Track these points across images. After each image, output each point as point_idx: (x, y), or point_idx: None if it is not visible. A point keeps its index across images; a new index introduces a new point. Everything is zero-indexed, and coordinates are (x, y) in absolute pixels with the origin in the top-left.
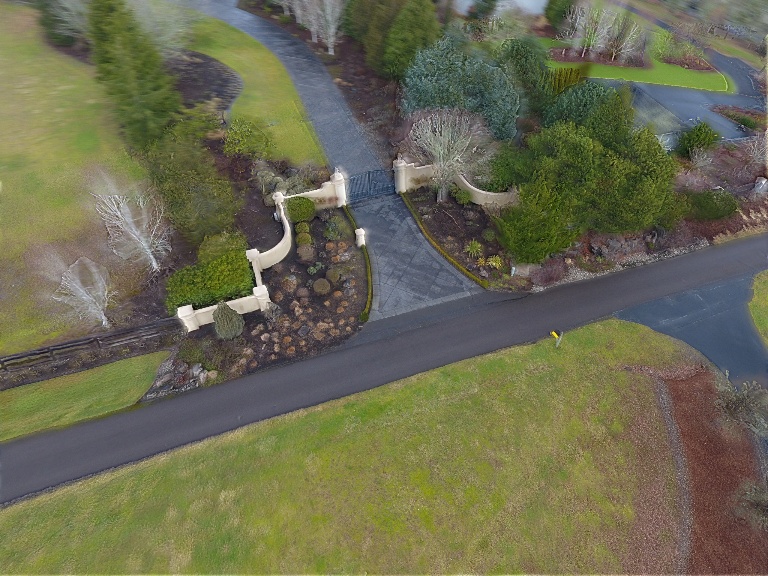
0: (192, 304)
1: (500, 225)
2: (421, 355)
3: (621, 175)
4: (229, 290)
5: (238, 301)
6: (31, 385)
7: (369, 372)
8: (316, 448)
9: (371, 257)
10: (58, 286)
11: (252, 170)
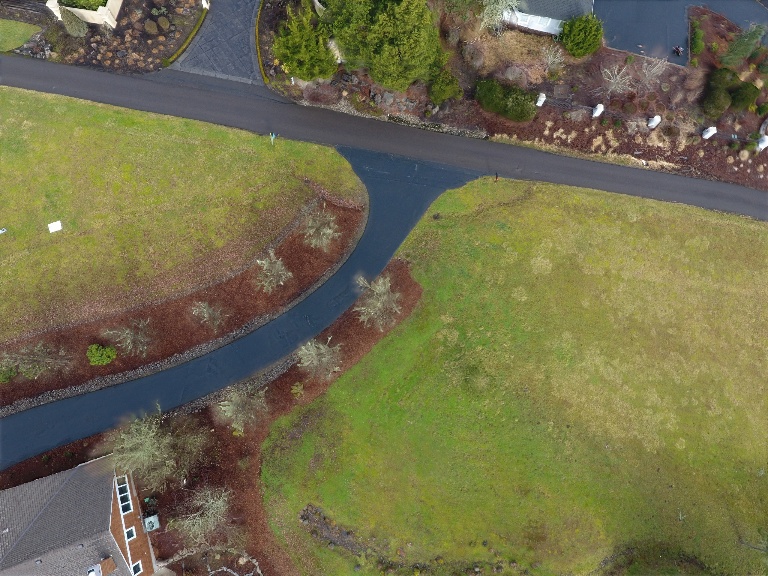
0: None
1: None
2: (182, 106)
3: (386, 37)
4: (82, 0)
5: (88, 12)
6: None
7: (143, 100)
8: (84, 125)
9: (206, 21)
10: None
11: None
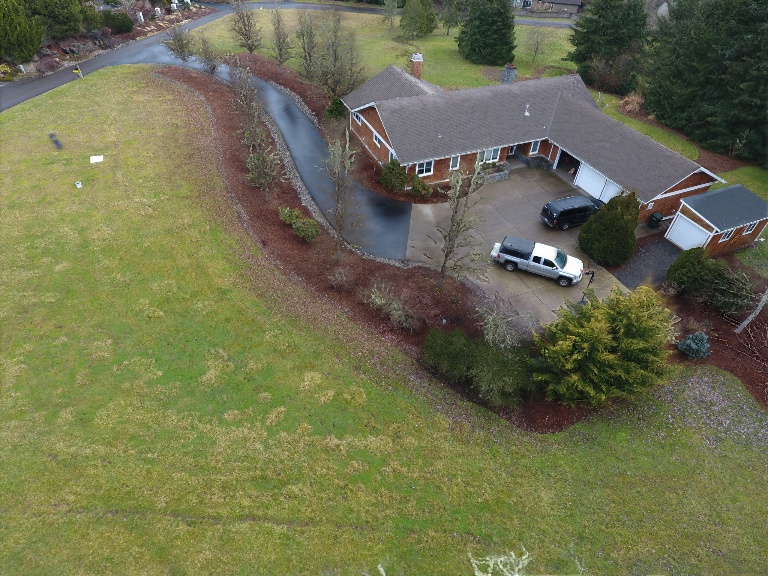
0: None
1: None
2: None
3: None
4: None
5: None
6: None
7: None
8: None
9: None
10: None
11: None
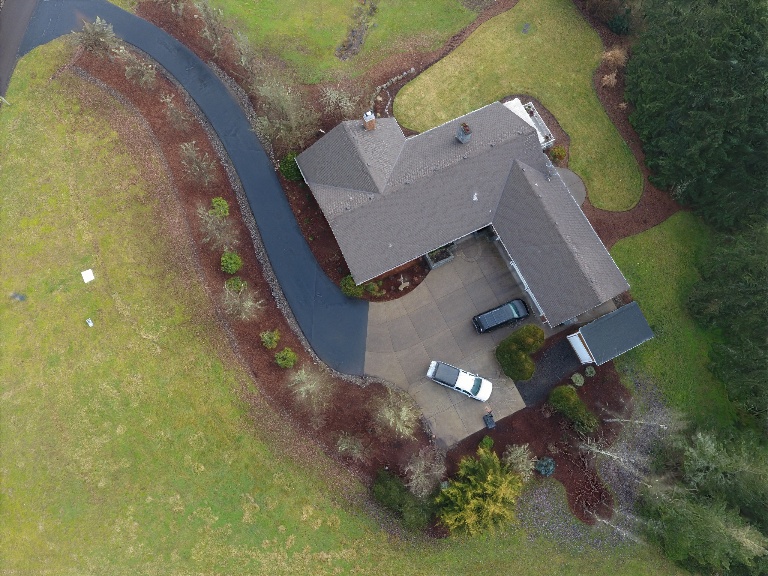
0: None
1: None
2: None
3: None
4: None
5: None
6: None
7: None
8: None
9: None
10: None
11: None
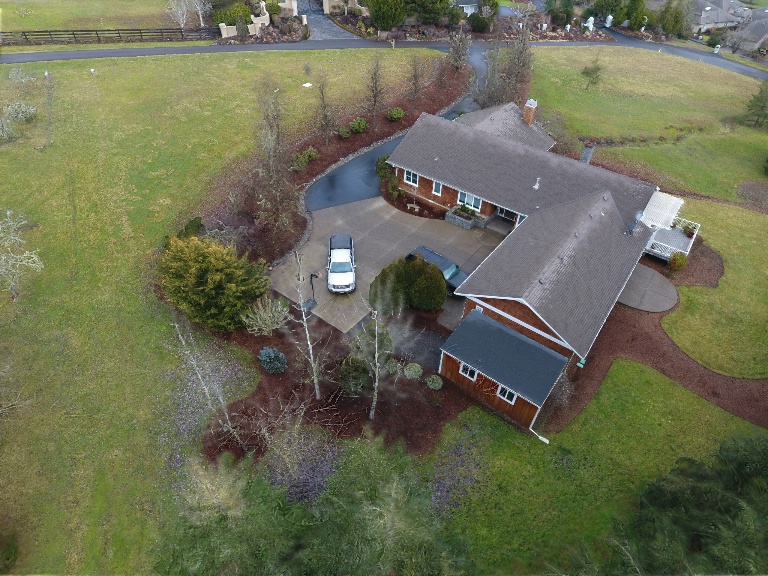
0: (225, 24)
1: (370, 7)
2: (331, 46)
3: None
4: None
5: None
6: (155, 42)
7: (307, 47)
8: None
9: (310, 28)
10: (155, 25)
11: (247, 2)
